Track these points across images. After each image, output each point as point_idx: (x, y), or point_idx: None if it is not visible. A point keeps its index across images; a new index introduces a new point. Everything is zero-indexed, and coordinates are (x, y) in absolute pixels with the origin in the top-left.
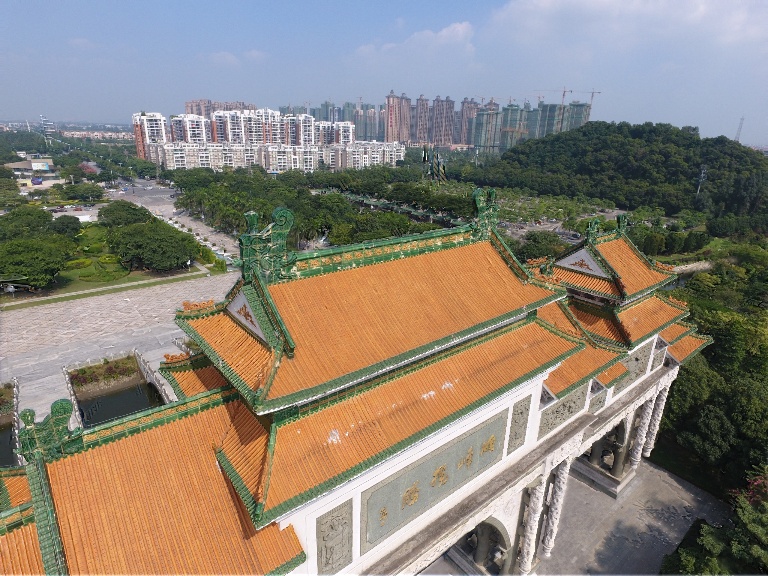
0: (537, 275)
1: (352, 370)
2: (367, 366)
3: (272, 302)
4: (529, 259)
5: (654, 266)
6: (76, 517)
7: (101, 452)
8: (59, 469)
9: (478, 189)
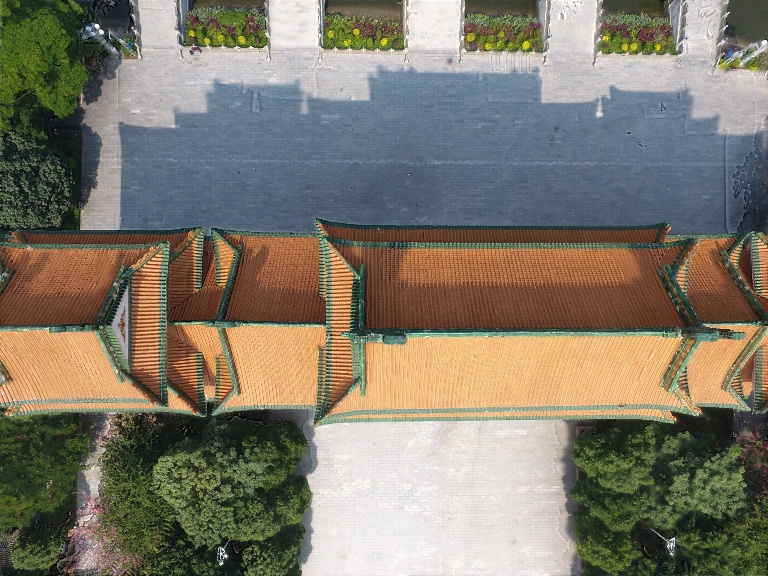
0: (683, 393)
1: (403, 407)
2: (416, 408)
3: (363, 366)
4: None
5: None
6: (240, 350)
7: (254, 328)
8: (231, 329)
9: (710, 337)
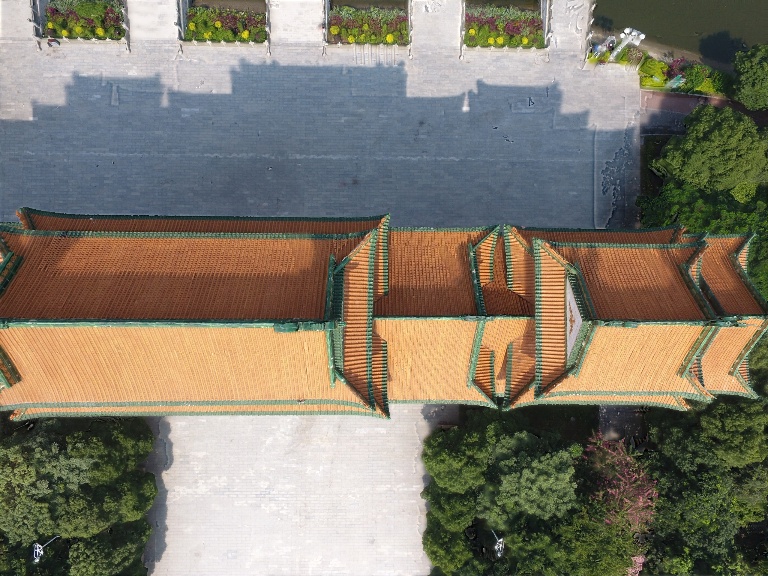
0: (348, 387)
1: (71, 400)
2: (85, 402)
3: None
4: (548, 244)
5: (689, 377)
6: None
7: None
8: None
9: (281, 328)
